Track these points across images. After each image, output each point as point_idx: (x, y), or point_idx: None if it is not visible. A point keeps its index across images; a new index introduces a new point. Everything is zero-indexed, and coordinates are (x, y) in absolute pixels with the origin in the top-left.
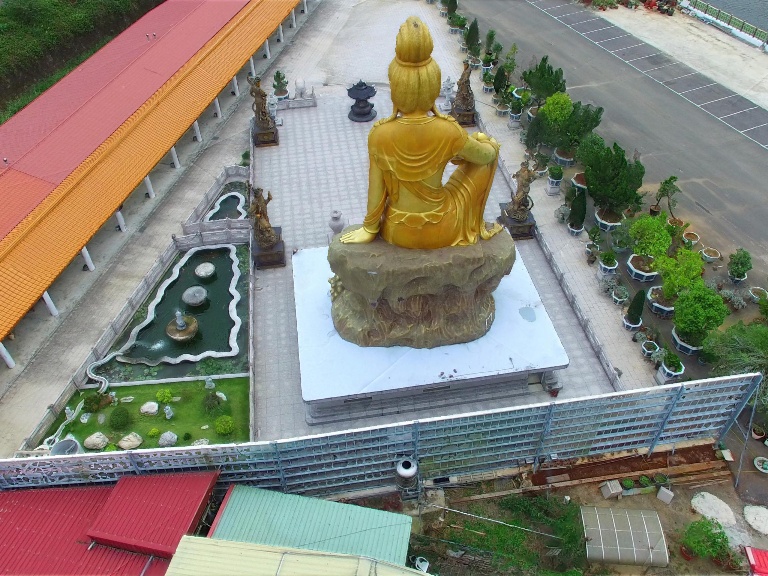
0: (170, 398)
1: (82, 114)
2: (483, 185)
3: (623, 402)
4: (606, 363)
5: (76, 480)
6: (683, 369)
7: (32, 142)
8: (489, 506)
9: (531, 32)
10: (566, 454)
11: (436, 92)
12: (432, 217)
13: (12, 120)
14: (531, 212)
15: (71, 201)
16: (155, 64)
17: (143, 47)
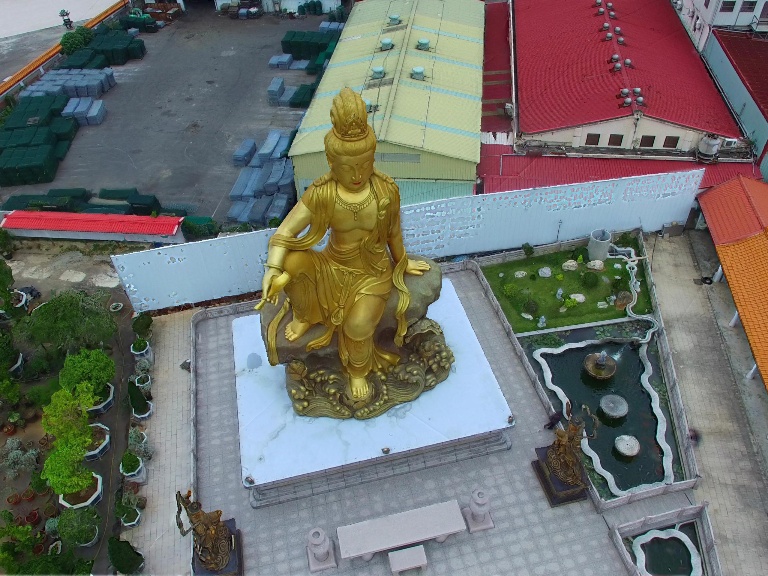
0: None
1: None
2: None
3: None
4: None
5: None
6: None
7: None
8: None
9: None
10: (257, 288)
11: None
12: None
13: None
14: None
15: None
16: None
17: None
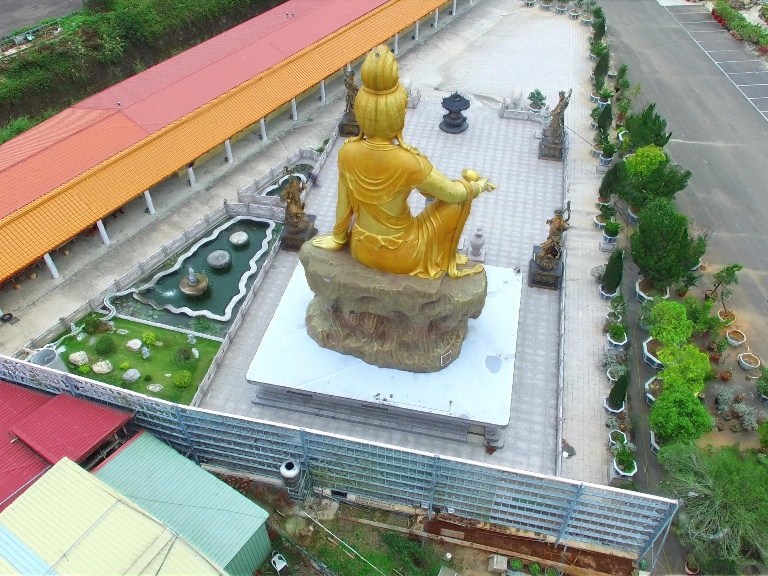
0: (154, 341)
1: (198, 76)
2: (452, 223)
3: (516, 480)
4: (564, 438)
5: (34, 384)
6: (634, 471)
7: (148, 92)
8: (372, 534)
9: (679, 73)
10: (464, 512)
11: (395, 122)
12: (389, 242)
13: (150, 69)
14: (571, 263)
15: (148, 150)
16: (281, 41)
17: (279, 24)
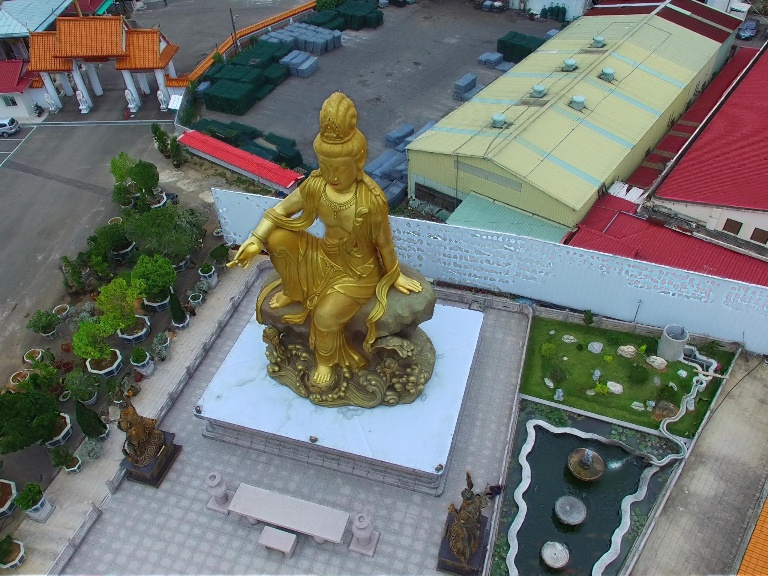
0: None
1: None
2: None
3: None
4: None
5: None
6: None
7: None
8: None
9: None
10: None
11: None
12: None
13: None
14: None
15: None
16: None
17: None
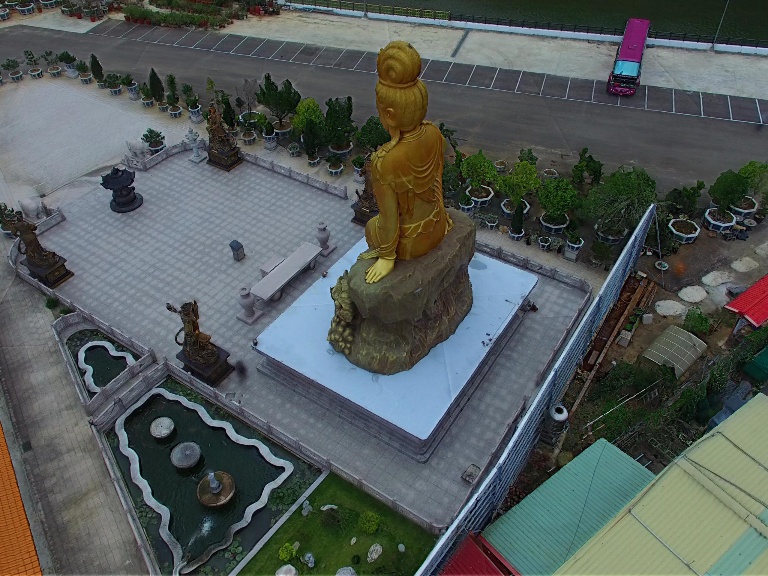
0: None
1: None
2: None
3: None
4: None
5: None
6: None
7: None
8: (585, 407)
9: (187, 67)
10: None
11: None
12: (436, 215)
13: None
14: None
15: None
16: None
17: None
